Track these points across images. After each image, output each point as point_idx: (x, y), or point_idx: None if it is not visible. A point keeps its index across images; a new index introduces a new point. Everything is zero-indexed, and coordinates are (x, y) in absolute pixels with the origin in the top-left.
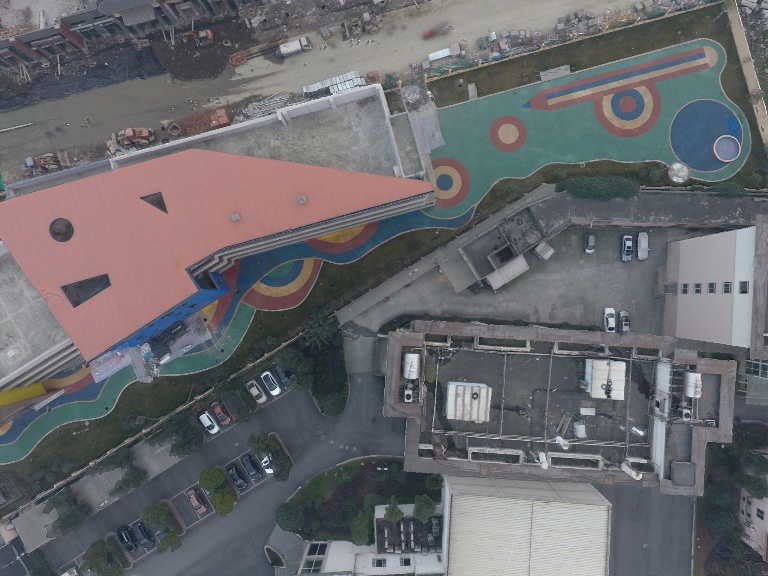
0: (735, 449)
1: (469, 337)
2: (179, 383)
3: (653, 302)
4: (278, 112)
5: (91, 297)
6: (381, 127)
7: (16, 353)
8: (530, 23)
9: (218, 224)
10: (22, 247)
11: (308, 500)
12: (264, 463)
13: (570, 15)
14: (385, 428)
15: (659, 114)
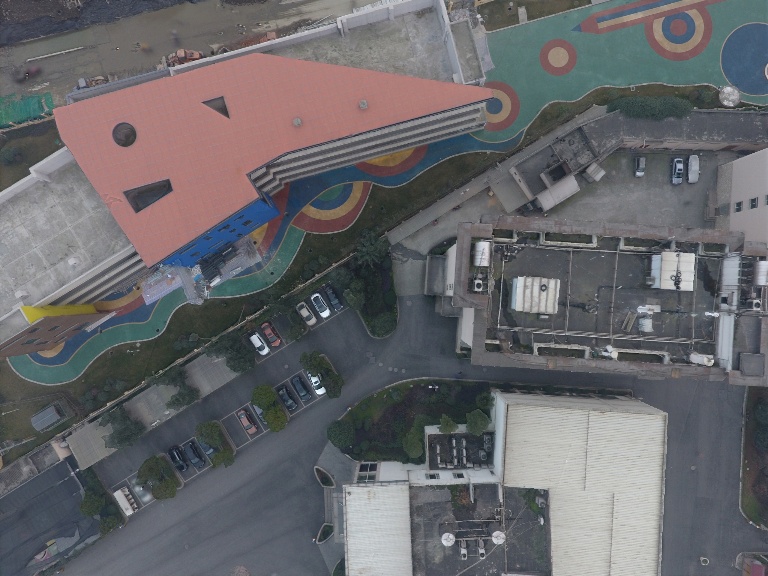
0: None
1: (535, 234)
2: (229, 305)
3: (703, 226)
4: (338, 20)
5: (153, 202)
6: (438, 38)
7: (76, 262)
8: None
9: (279, 129)
10: (85, 151)
11: (358, 420)
12: (314, 383)
13: None
14: (434, 351)
15: (710, 37)
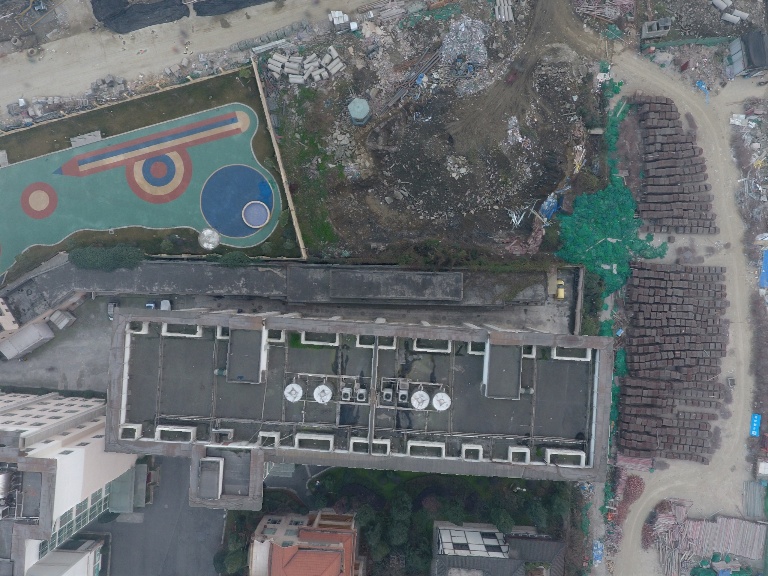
0: (246, 517)
1: None
2: None
3: None
4: None
5: None
6: None
7: None
8: (63, 88)
9: None
10: None
11: None
12: None
13: (97, 81)
14: None
15: (190, 180)
